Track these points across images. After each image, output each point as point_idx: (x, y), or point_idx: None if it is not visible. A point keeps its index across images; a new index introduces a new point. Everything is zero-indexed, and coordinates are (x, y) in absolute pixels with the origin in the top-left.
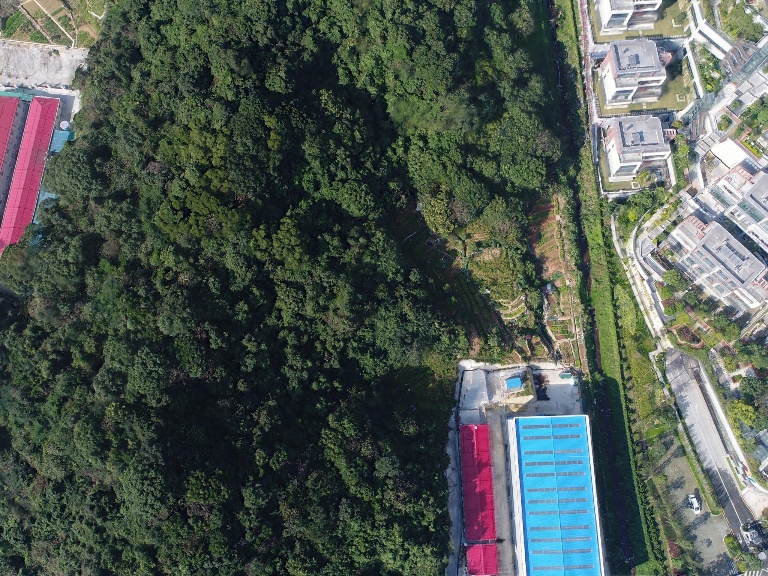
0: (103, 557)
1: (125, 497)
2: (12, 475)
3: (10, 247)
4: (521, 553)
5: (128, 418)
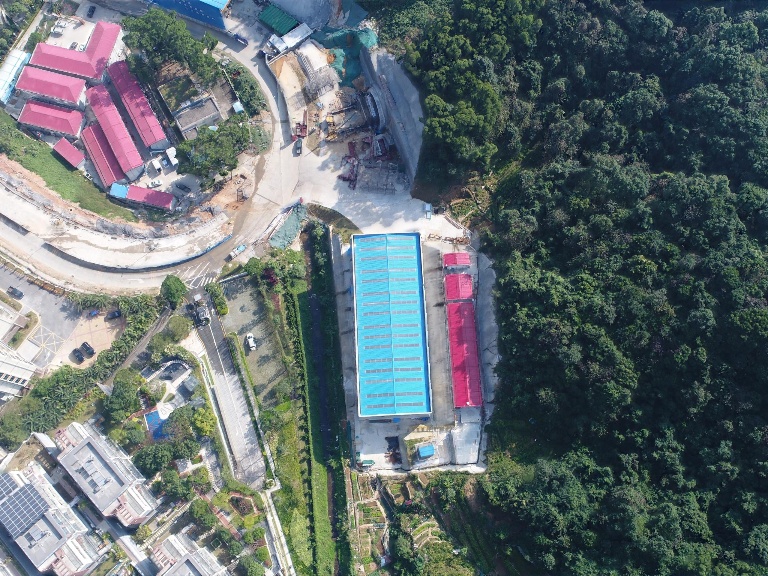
0: None
1: None
2: None
3: None
4: None
5: None
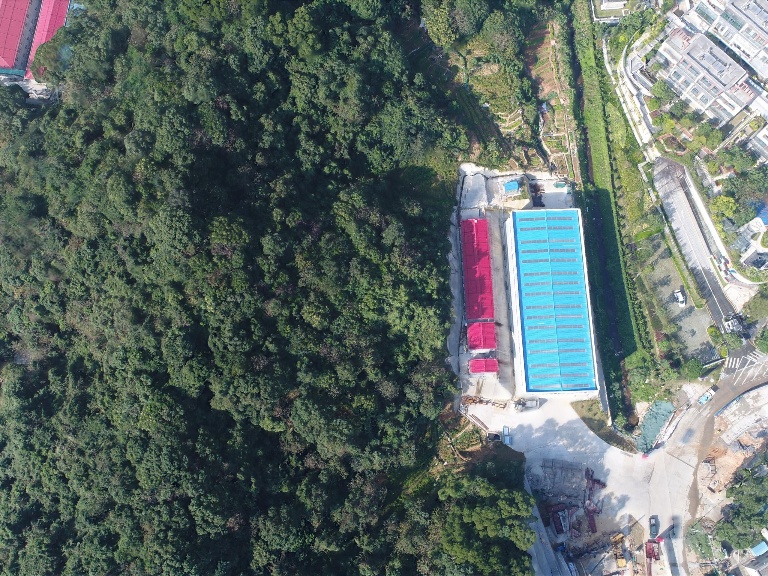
0: (134, 298)
1: (155, 238)
2: (49, 238)
3: (43, 44)
4: (518, 331)
5: (157, 173)
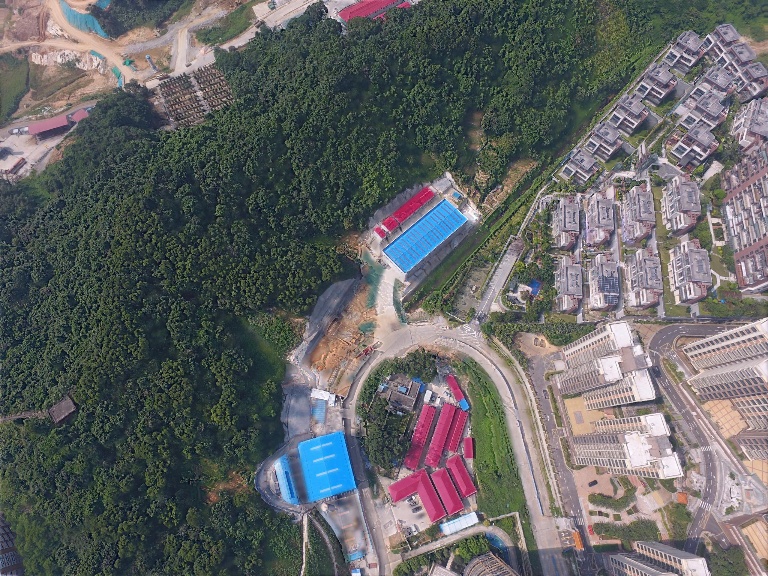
0: None
1: None
2: (299, 65)
3: None
4: None
5: None
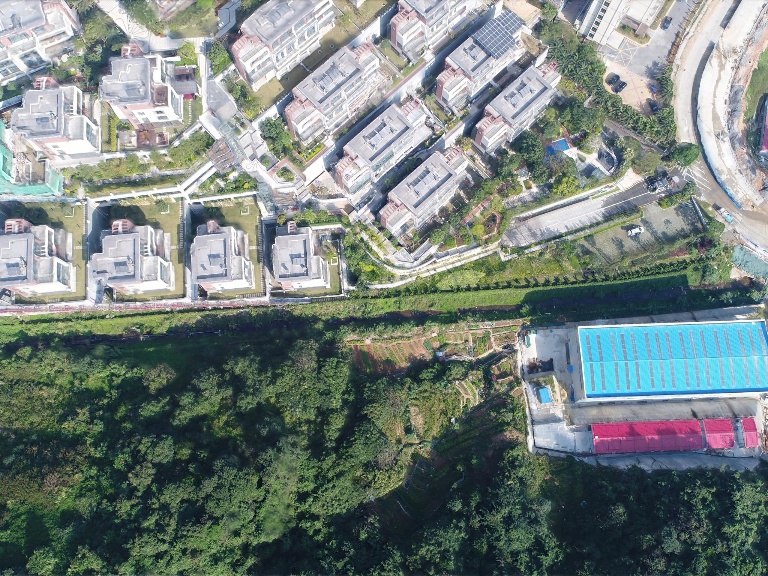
0: None
1: None
2: None
3: None
4: None
5: None
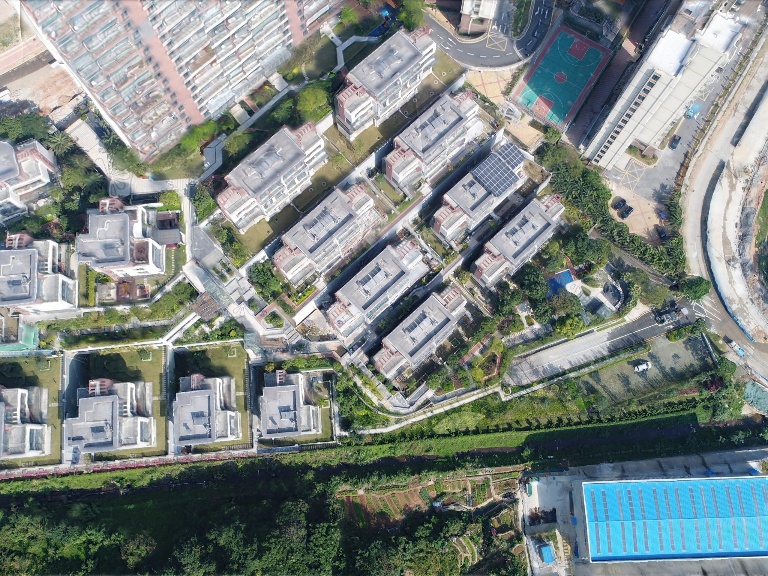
0: None
1: None
2: None
3: None
4: None
5: None
